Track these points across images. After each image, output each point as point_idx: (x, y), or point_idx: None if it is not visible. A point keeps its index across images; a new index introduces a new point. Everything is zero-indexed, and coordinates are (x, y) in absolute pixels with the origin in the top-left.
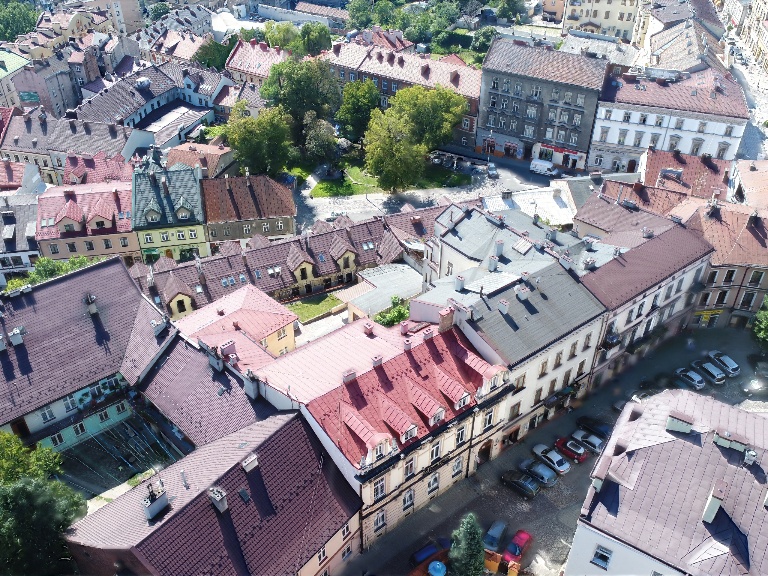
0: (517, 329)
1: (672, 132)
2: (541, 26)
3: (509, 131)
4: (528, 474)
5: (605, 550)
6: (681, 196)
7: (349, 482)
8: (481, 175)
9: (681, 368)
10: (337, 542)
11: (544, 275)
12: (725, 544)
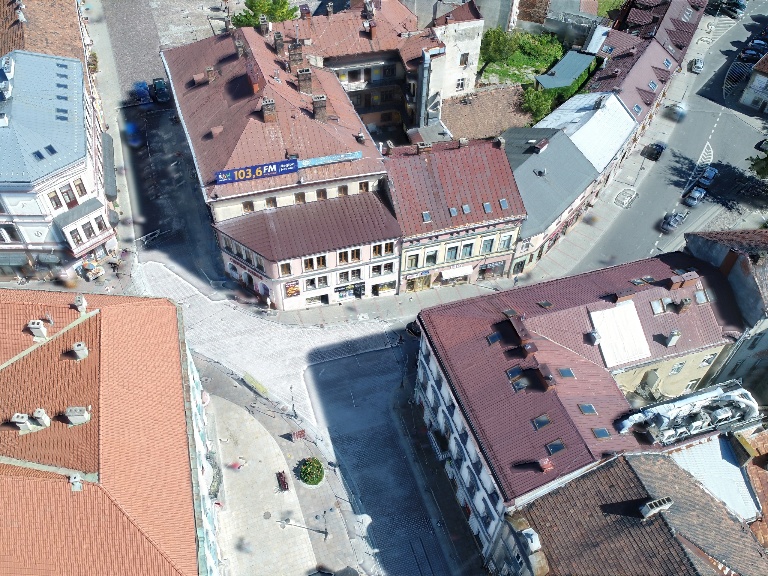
0: None
1: None
2: None
3: None
4: None
5: None
6: None
7: None
8: None
9: None
10: None
11: None
12: None
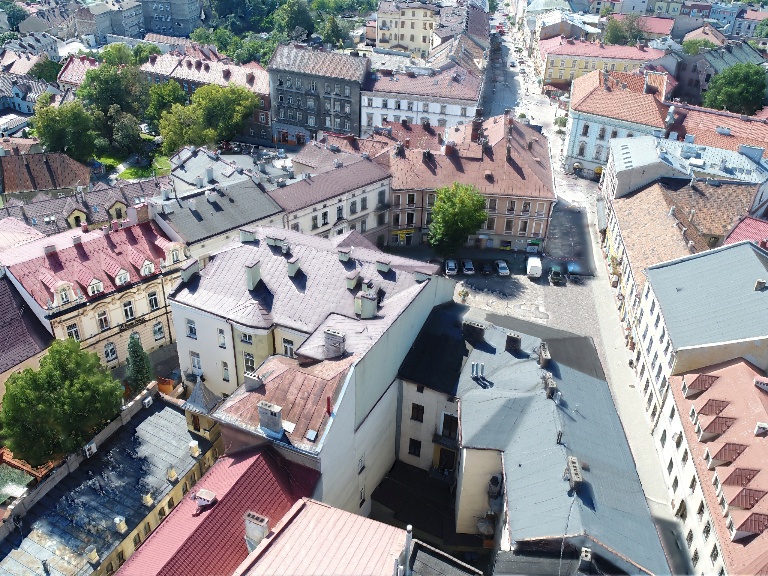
0: (201, 220)
1: (421, 115)
2: (361, 50)
3: (297, 122)
4: None
5: (193, 324)
6: (384, 145)
7: (45, 326)
8: (272, 159)
9: None
10: None
11: (236, 187)
12: (258, 300)
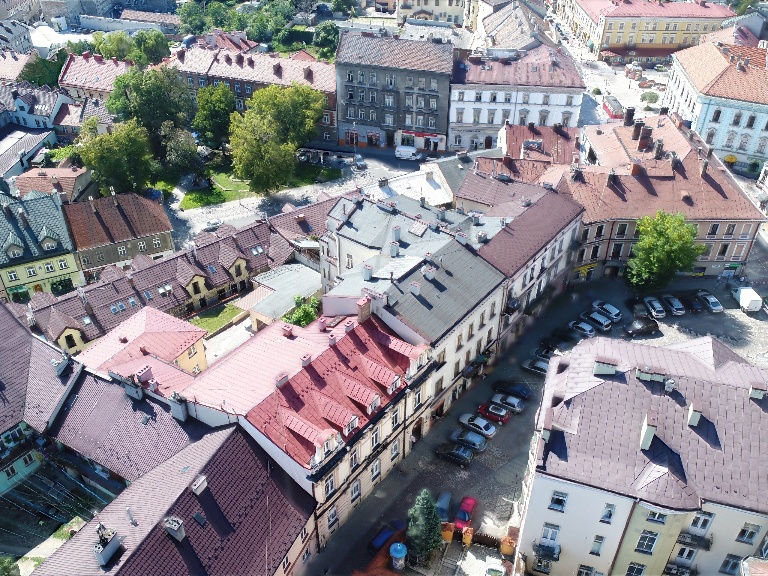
0: (431, 308)
1: (520, 107)
2: (376, 17)
3: (370, 121)
4: (460, 444)
5: (560, 494)
6: (546, 164)
7: (300, 485)
8: (350, 167)
9: (572, 321)
10: (297, 546)
11: (445, 253)
12: (663, 465)
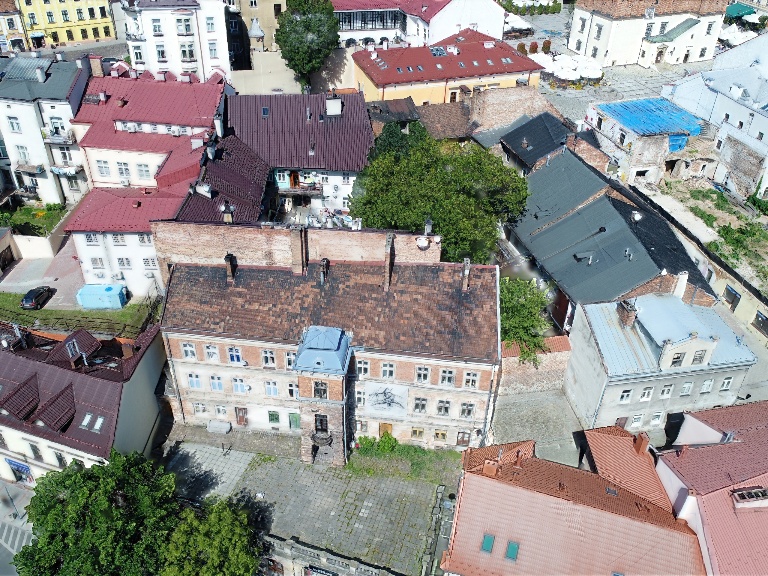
0: None
1: None
2: None
3: None
4: None
5: None
6: None
7: None
8: None
9: None
10: None
11: None
12: None
